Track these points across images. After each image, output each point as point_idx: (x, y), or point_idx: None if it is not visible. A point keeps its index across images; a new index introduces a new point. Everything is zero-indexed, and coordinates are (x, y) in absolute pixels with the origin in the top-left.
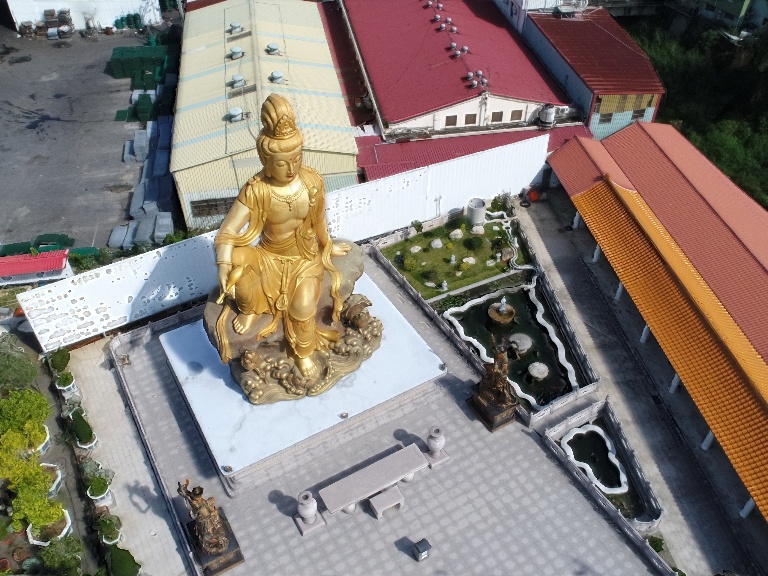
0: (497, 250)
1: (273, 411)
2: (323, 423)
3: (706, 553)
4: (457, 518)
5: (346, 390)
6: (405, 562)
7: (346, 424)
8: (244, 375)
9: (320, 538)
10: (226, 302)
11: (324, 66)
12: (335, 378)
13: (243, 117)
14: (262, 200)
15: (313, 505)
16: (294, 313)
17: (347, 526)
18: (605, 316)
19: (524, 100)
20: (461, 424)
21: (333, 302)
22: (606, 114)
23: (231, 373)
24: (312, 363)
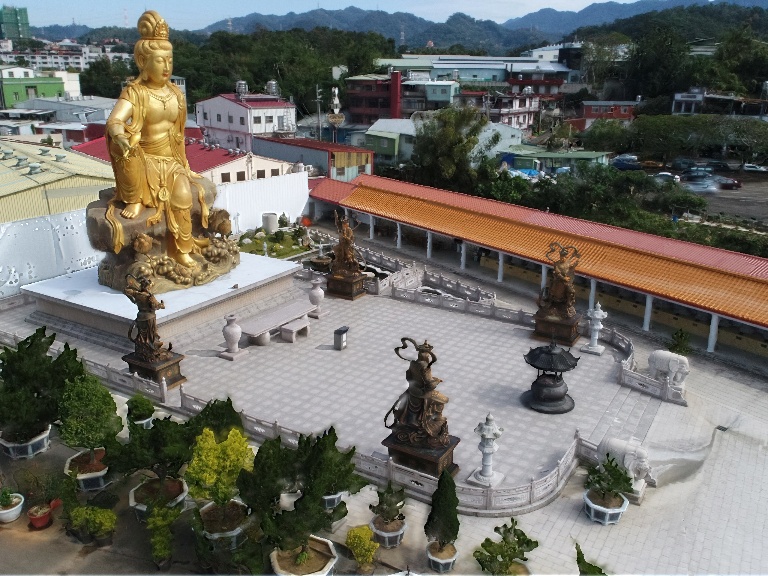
0: (298, 238)
1: (168, 295)
2: (219, 293)
3: (533, 311)
4: (356, 331)
5: (227, 280)
6: (330, 353)
7: (234, 306)
8: (136, 264)
9: (249, 359)
10: (109, 204)
11: (96, 163)
12: (214, 275)
13: (43, 170)
14: (142, 98)
15: (238, 326)
16: (176, 201)
17: (269, 350)
18: (396, 254)
19: (279, 160)
20: (327, 302)
21: (201, 208)
22: (340, 168)
23: (112, 288)
24: (192, 259)
